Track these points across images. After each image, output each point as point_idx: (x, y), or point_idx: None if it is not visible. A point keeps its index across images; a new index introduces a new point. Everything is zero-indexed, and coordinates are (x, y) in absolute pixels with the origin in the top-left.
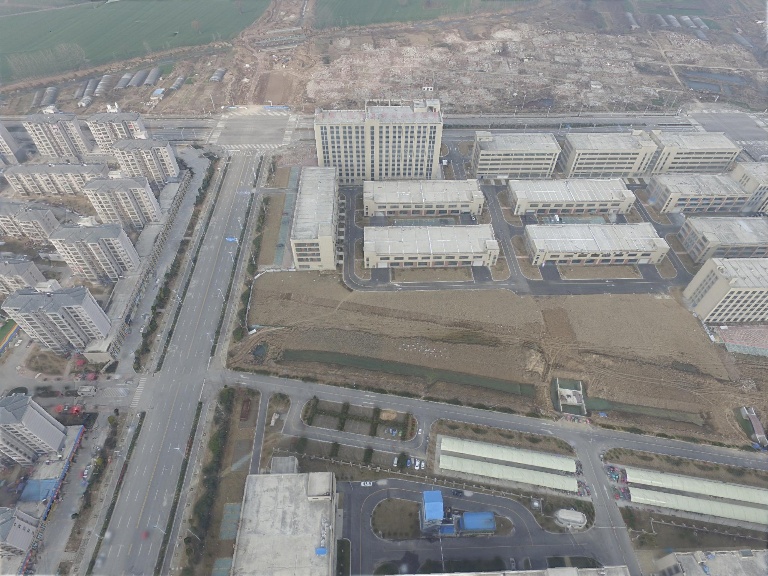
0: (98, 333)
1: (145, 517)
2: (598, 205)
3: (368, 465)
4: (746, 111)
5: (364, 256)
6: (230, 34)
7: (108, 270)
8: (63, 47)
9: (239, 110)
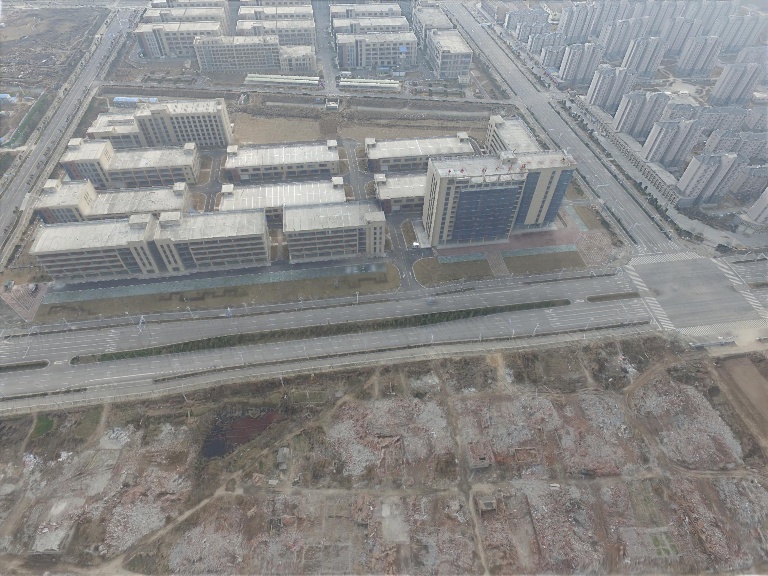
0: None
1: None
2: None
3: None
4: None
5: None
6: None
7: None
8: None
9: (765, 334)
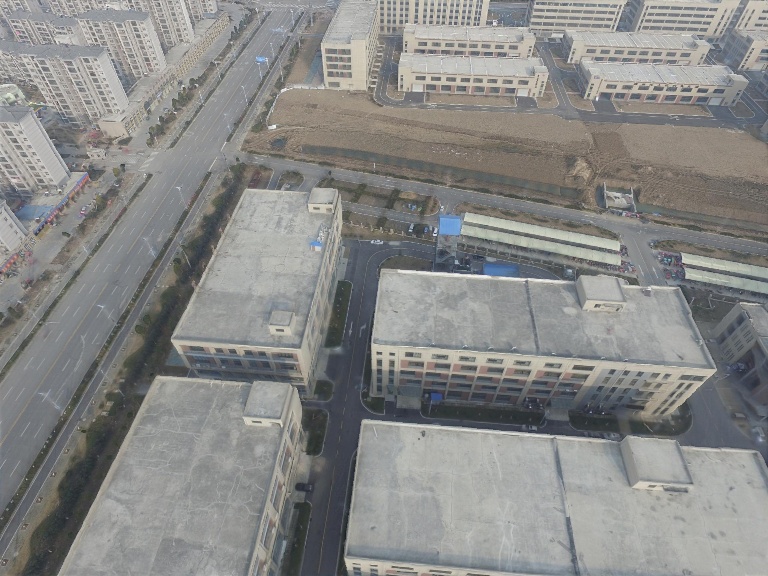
0: (114, 104)
1: (137, 247)
2: (665, 54)
3: (380, 227)
4: None
5: (398, 73)
6: None
7: (133, 64)
8: None
9: None
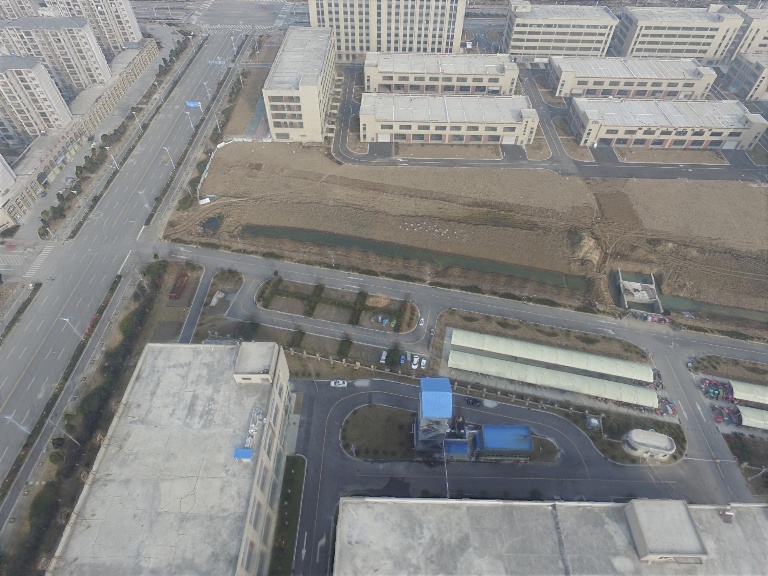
0: None
1: (7, 411)
2: (666, 85)
3: (343, 359)
4: None
5: (360, 122)
6: None
7: (25, 121)
8: None
9: None
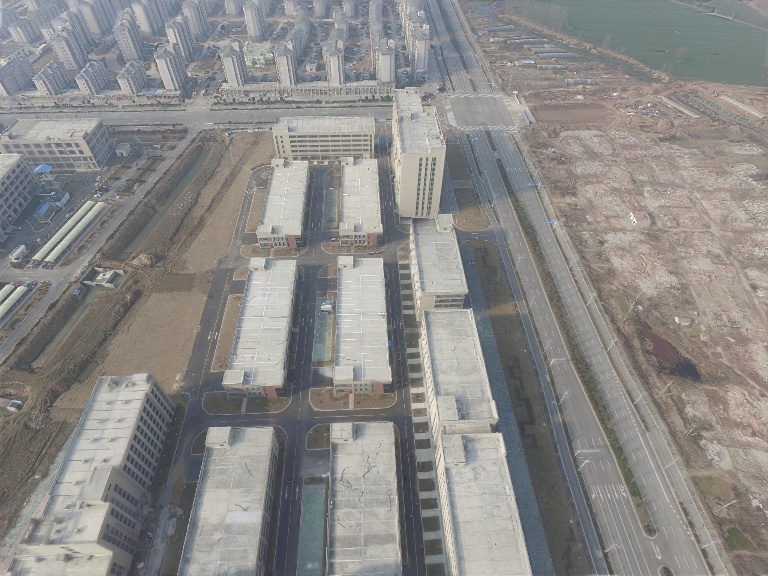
0: None
1: None
2: None
3: None
4: None
5: None
6: (690, 76)
7: None
8: (557, 8)
9: (514, 100)
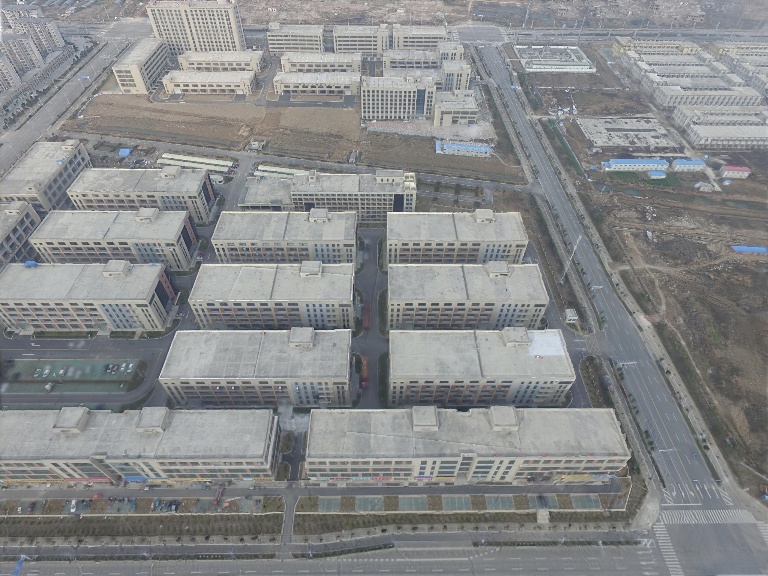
0: None
1: None
2: (337, 66)
3: None
4: (500, 26)
5: (163, 83)
6: None
7: None
8: None
9: (127, 20)
